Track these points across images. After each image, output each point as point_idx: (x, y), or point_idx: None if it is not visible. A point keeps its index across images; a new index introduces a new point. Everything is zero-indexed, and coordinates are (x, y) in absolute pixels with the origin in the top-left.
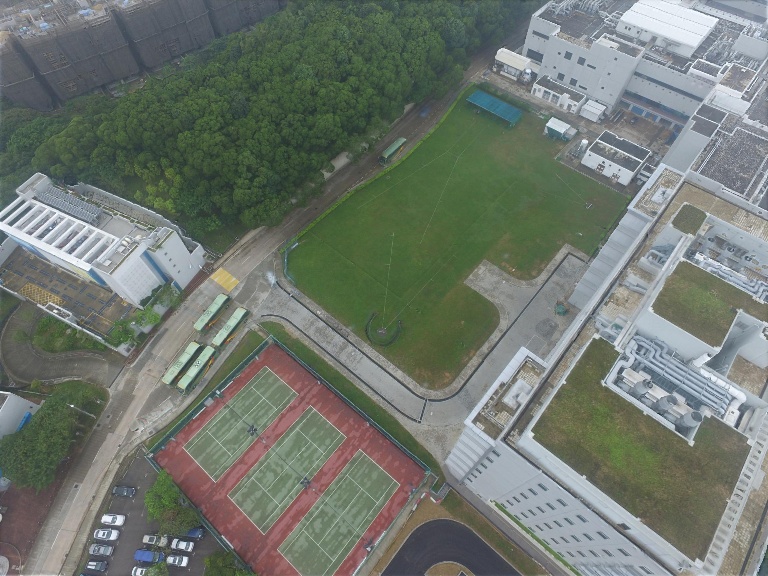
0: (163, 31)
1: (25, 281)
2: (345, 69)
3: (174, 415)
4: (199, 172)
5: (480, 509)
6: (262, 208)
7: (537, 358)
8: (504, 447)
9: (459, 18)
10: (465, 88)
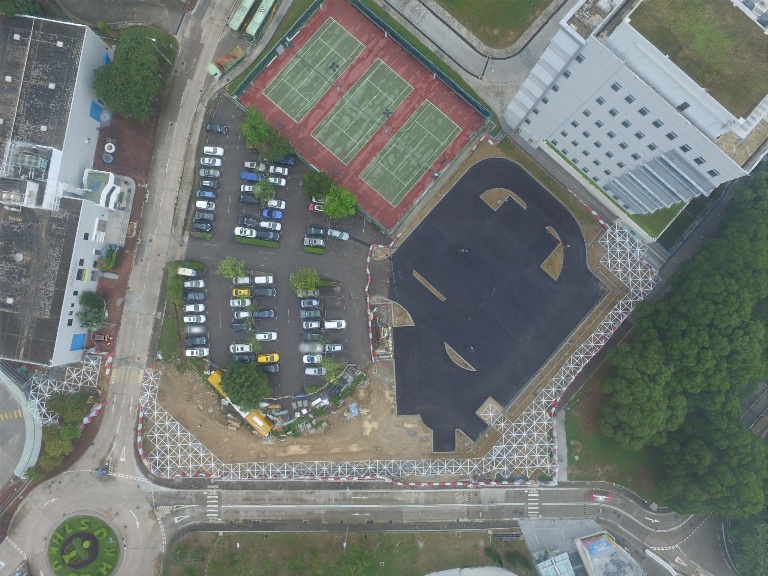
0: None
1: None
2: None
3: (247, 64)
4: None
5: (529, 152)
6: None
7: None
8: (595, 41)
9: None
10: None
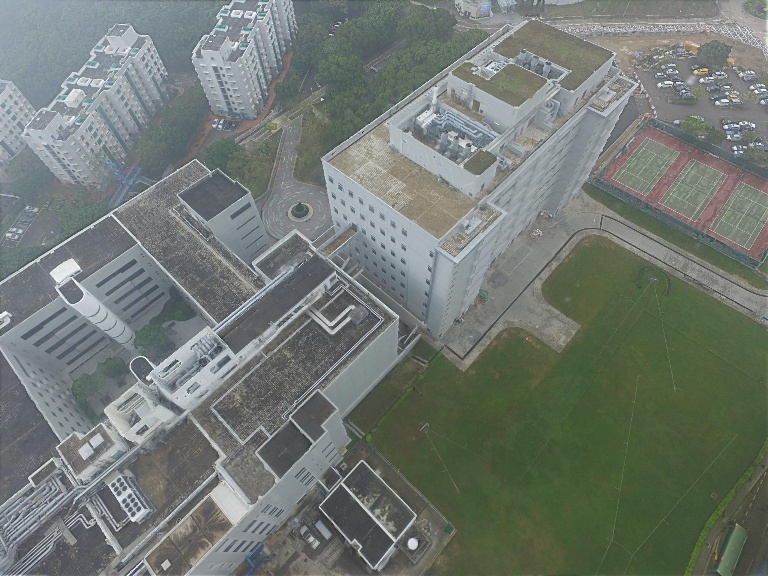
0: None
1: None
2: None
3: None
4: None
5: None
6: None
7: (595, 111)
8: None
9: None
10: None
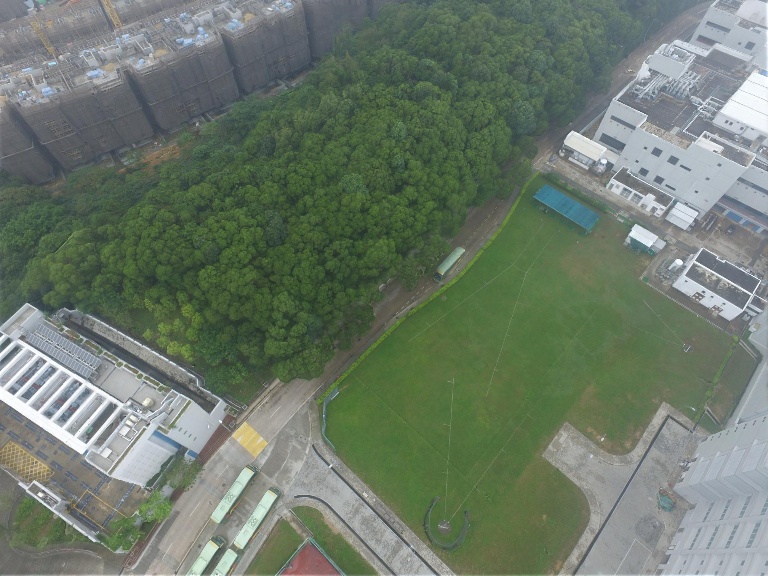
0: (182, 92)
1: (7, 438)
2: (401, 177)
3: None
4: (224, 316)
5: None
6: (300, 361)
7: None
8: None
9: (526, 99)
10: (529, 179)
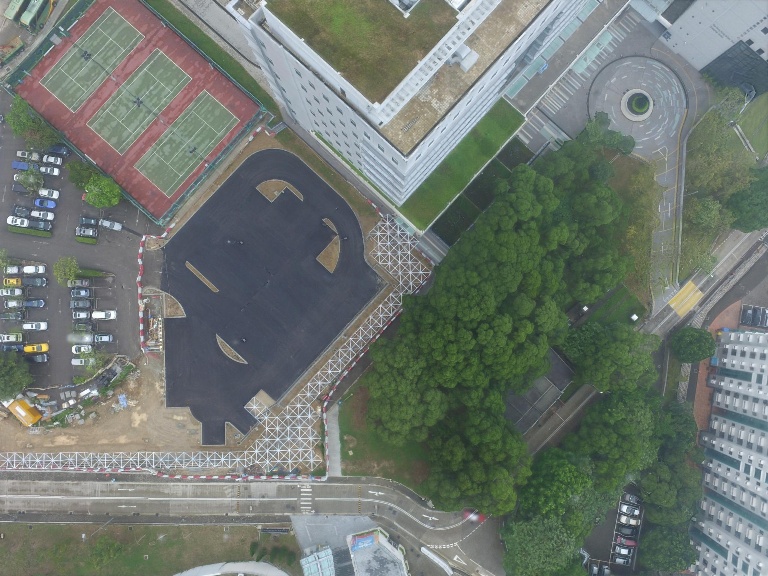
0: None
1: None
2: None
3: (27, 53)
4: None
5: (310, 144)
6: None
7: None
8: (253, 25)
9: None
10: None
